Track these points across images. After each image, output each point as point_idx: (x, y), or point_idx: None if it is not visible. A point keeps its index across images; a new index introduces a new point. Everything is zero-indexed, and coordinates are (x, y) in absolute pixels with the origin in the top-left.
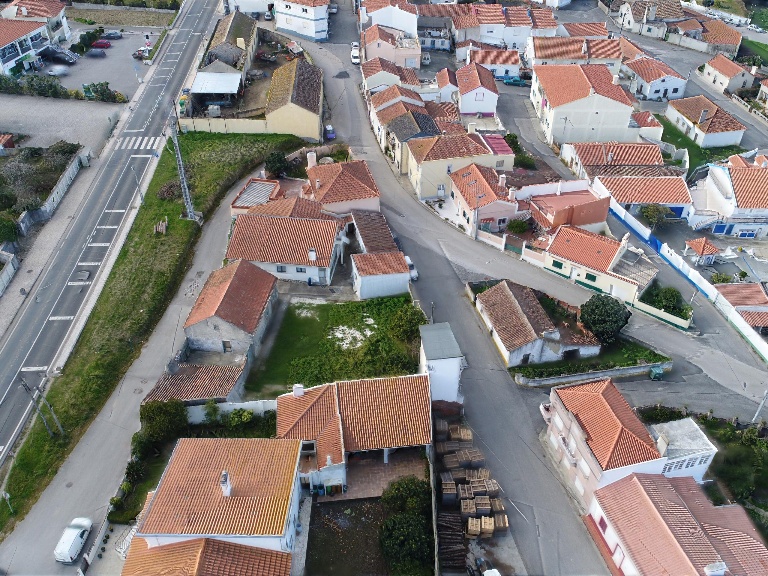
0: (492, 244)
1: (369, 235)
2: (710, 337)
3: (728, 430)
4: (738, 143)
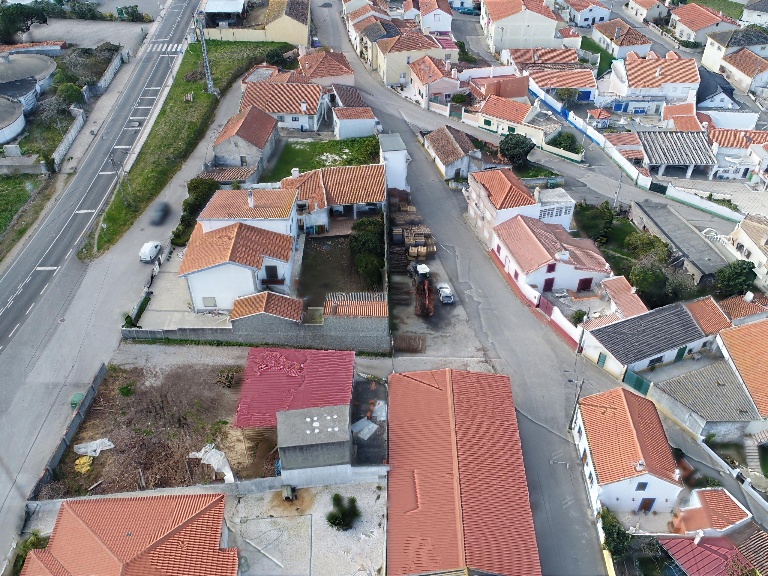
0: (440, 112)
1: (346, 99)
2: (596, 167)
3: None
4: None
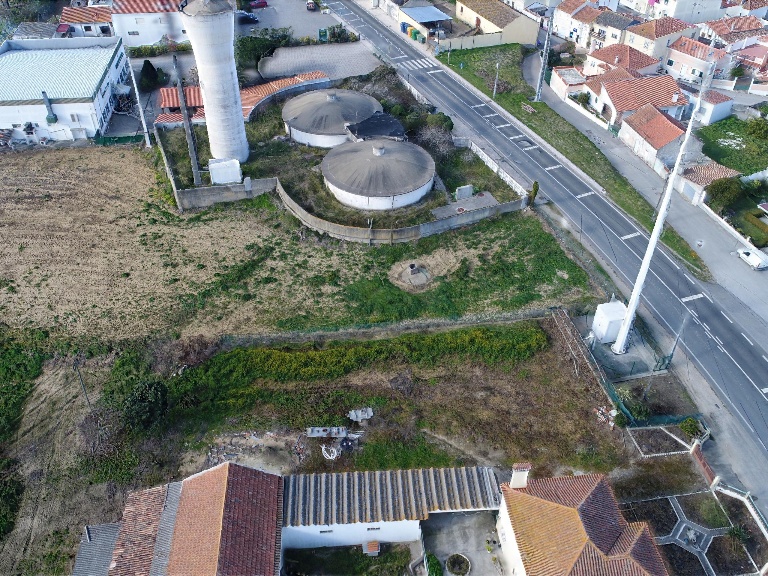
0: (723, 88)
1: None
2: None
3: None
4: (764, 16)
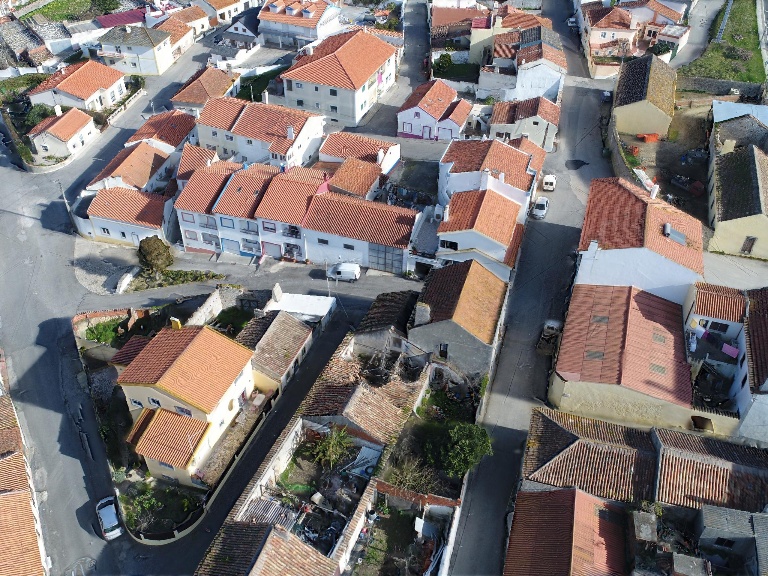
0: None
1: None
2: (424, 2)
3: None
4: None
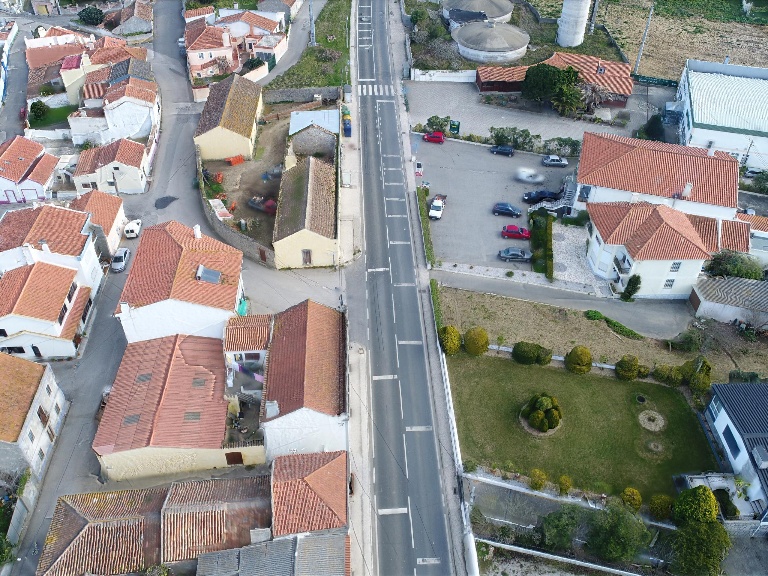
0: None
1: None
2: None
3: (75, 4)
4: None
